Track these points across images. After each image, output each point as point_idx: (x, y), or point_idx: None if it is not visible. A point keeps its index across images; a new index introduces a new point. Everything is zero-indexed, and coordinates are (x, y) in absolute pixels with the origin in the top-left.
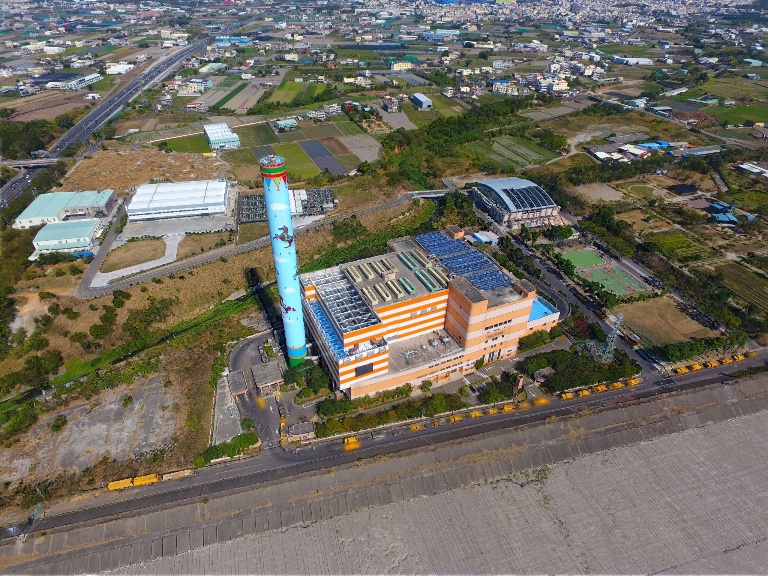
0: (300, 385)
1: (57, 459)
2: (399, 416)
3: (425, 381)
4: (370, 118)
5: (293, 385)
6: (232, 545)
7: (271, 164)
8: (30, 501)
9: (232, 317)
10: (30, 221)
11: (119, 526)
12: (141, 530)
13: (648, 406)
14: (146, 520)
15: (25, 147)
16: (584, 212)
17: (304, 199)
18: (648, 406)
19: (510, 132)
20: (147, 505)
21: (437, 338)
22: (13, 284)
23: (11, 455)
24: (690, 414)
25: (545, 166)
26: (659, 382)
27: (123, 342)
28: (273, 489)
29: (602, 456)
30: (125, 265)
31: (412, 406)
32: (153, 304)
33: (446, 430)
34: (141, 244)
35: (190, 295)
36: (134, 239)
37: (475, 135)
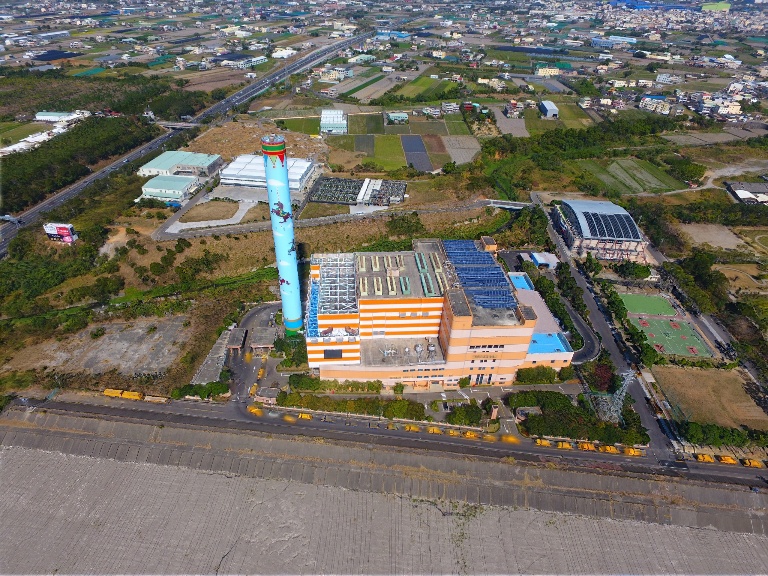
0: (287, 355)
1: (84, 360)
2: (356, 408)
3: (399, 383)
4: (484, 121)
5: (282, 353)
6: (166, 470)
7: (268, 142)
8: (51, 385)
9: (264, 282)
10: (150, 171)
11: (95, 424)
12: (108, 433)
13: (634, 482)
14: (114, 426)
15: (178, 112)
16: (680, 254)
17: (376, 189)
18: (634, 482)
19: (637, 153)
20: (121, 415)
21: (425, 345)
22: (115, 218)
23: (58, 347)
24: (686, 509)
25: (662, 196)
26: (667, 462)
27: (173, 282)
28: (217, 435)
29: (550, 517)
30: (199, 219)
31: (373, 403)
32: (206, 256)
33: (398, 436)
34: (220, 204)
35: (239, 255)
36: (217, 199)
37: (594, 152)
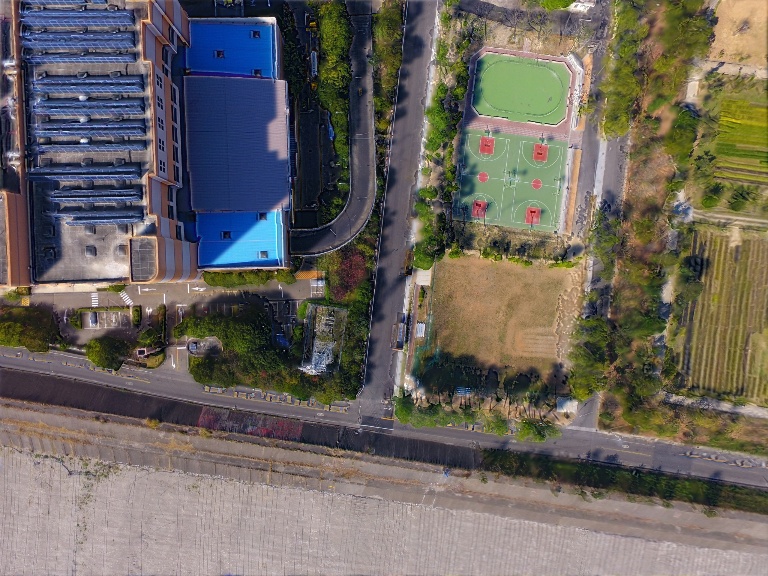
0: None
1: None
2: None
3: None
4: None
5: None
6: None
7: None
8: None
9: None
10: None
11: None
12: None
13: (304, 455)
14: None
15: None
16: None
17: None
18: (304, 455)
19: None
20: None
21: None
22: None
23: None
24: (355, 483)
25: None
26: (370, 419)
27: None
28: None
29: (195, 480)
30: None
31: None
32: None
33: (20, 366)
34: None
35: None
36: None
37: None
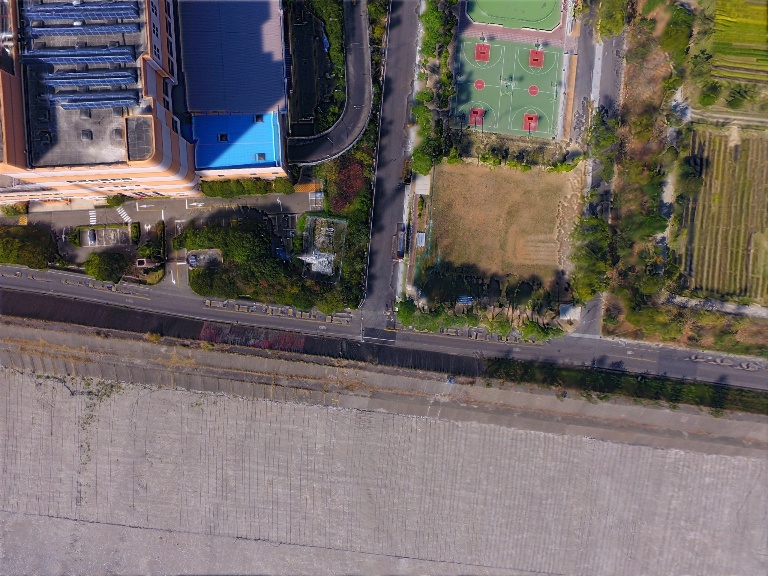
0: None
1: None
2: None
3: None
4: None
5: None
6: None
7: None
8: None
9: None
10: None
11: None
12: None
13: (307, 367)
14: None
15: None
16: None
17: None
18: (307, 367)
19: None
20: None
21: None
22: None
23: None
24: (359, 395)
25: None
26: (372, 331)
27: None
28: None
29: (198, 397)
30: None
31: None
32: None
33: (20, 286)
34: None
35: None
36: None
37: None
